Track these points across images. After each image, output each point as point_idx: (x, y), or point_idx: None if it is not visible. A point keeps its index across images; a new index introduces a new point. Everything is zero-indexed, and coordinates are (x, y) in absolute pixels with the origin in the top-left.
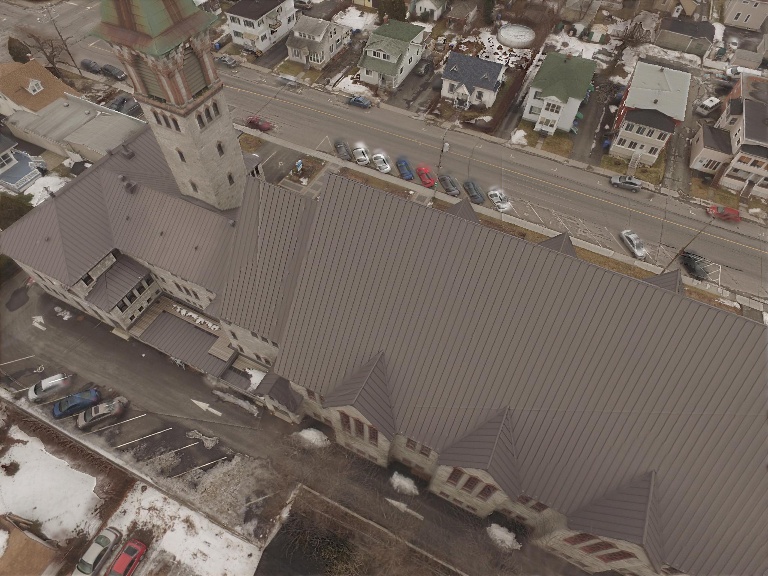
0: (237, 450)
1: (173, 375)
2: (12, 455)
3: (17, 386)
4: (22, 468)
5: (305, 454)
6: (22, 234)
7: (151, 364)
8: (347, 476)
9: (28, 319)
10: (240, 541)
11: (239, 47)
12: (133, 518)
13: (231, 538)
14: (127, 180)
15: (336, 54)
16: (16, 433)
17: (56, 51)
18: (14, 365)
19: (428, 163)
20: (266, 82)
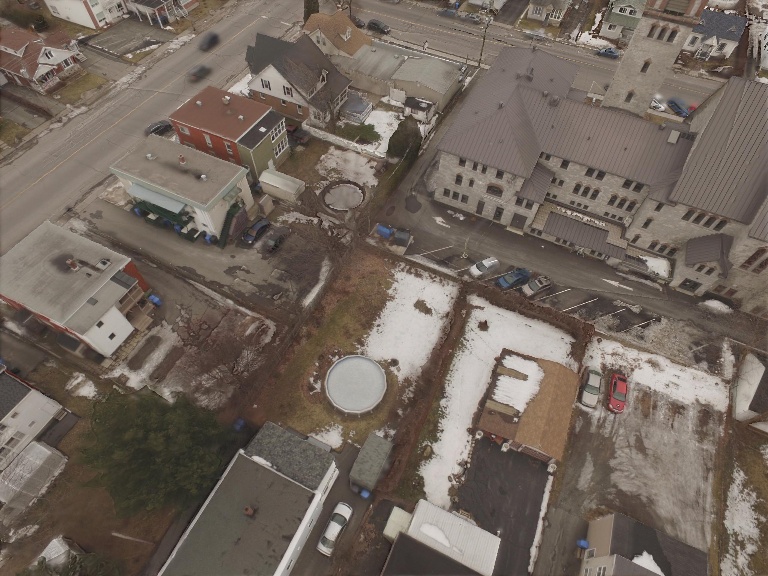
0: (661, 314)
1: (576, 261)
2: (476, 317)
3: (455, 267)
4: (491, 326)
5: (717, 318)
6: (474, 138)
7: (553, 253)
8: (760, 333)
9: (431, 219)
10: (704, 374)
11: (475, 6)
12: (601, 361)
13: (696, 372)
14: (549, 96)
15: (565, 13)
16: (473, 301)
17: (344, 5)
18: (442, 252)
19: (695, 104)
20: (514, 36)
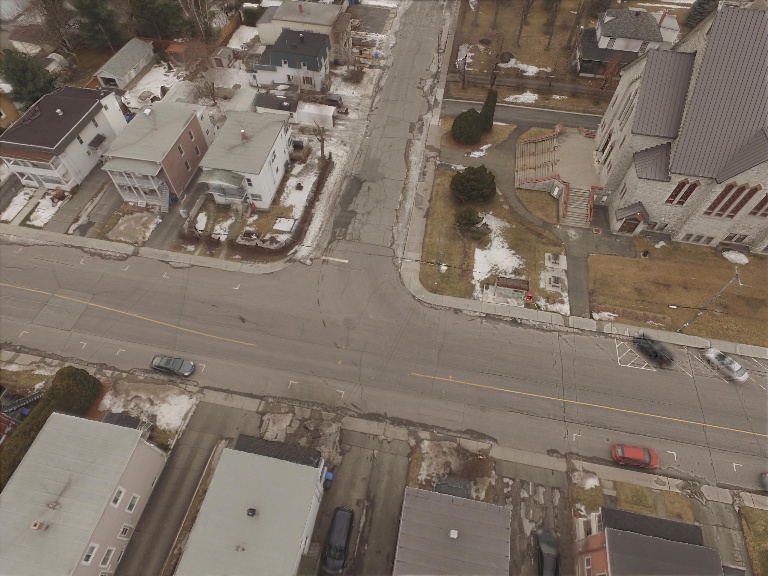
0: None
1: None
2: None
3: None
4: None
5: None
6: None
7: None
8: None
9: None
10: None
11: None
12: None
13: None
14: None
15: None
16: None
17: None
18: None
19: None
20: None
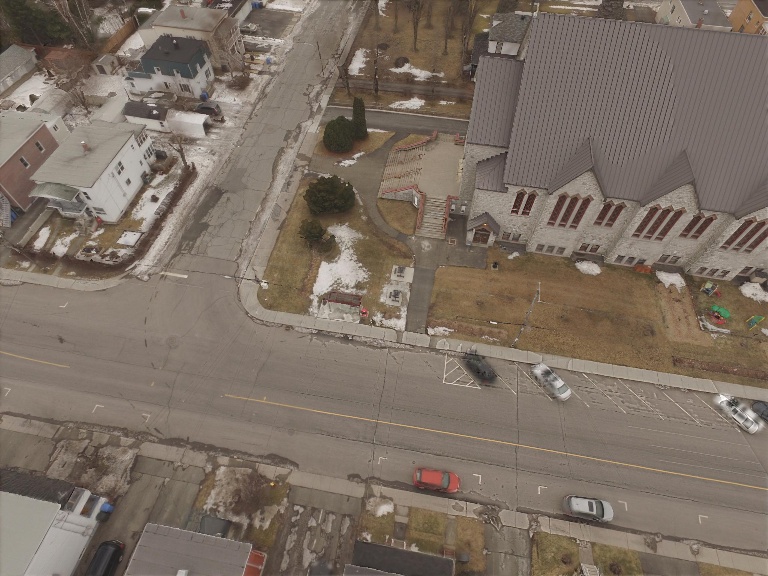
0: None
1: None
2: None
3: None
4: None
5: None
6: None
7: None
8: None
9: None
10: None
11: None
12: None
13: None
14: None
15: None
16: None
17: None
18: None
19: None
20: None
